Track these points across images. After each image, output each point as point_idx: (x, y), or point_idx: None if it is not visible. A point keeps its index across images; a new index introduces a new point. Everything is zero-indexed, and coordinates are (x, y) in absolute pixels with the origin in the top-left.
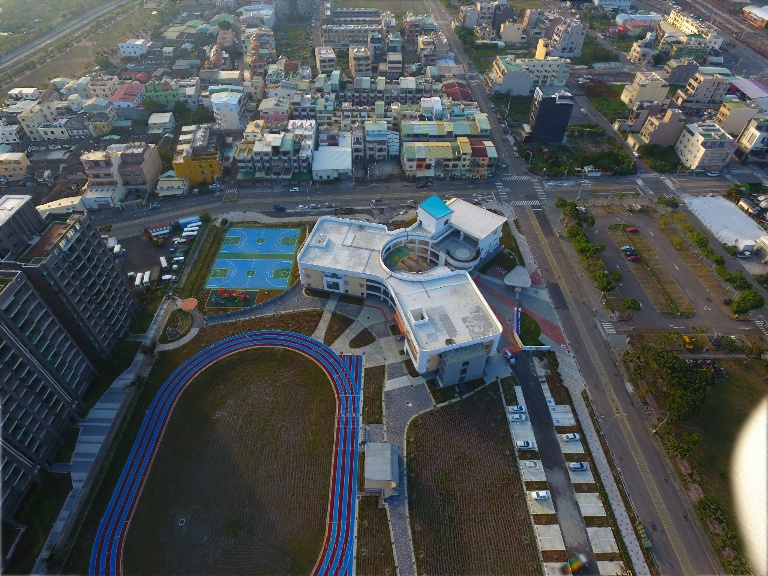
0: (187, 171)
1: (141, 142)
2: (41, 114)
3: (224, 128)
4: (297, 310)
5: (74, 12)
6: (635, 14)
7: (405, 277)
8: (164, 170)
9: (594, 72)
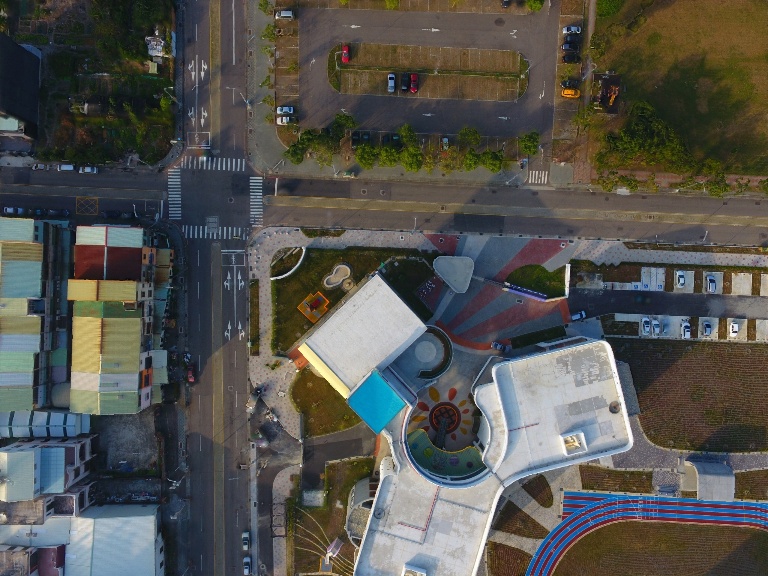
0: None
1: None
2: None
3: None
4: None
5: None
6: None
7: None
8: None
9: None
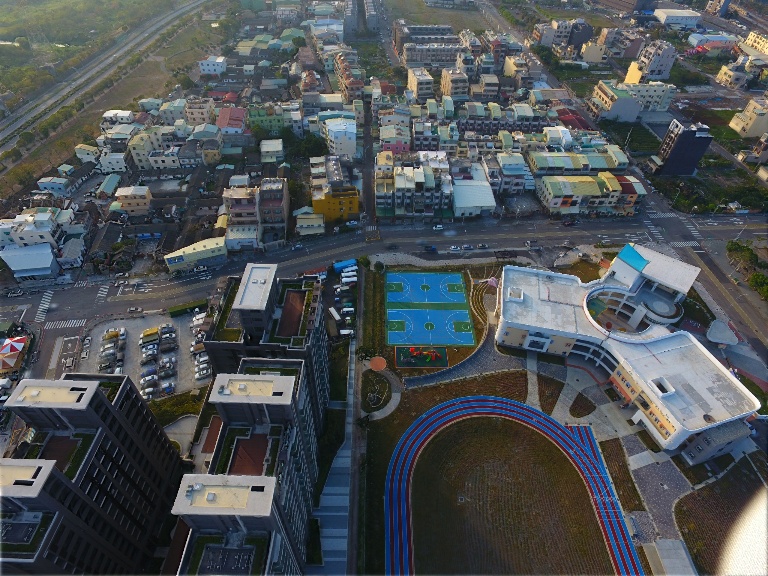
0: (325, 208)
1: (257, 172)
2: (149, 141)
3: (351, 159)
4: (498, 371)
5: (132, 24)
6: (706, 34)
7: (627, 339)
8: (293, 205)
9: (690, 96)
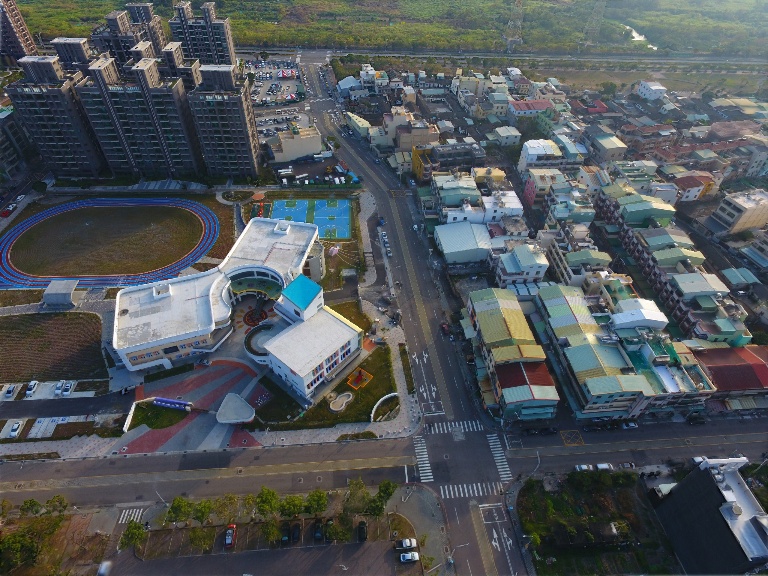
0: None
1: (470, 135)
2: (476, 85)
3: None
4: None
5: (718, 52)
6: None
7: (214, 281)
8: None
9: None
